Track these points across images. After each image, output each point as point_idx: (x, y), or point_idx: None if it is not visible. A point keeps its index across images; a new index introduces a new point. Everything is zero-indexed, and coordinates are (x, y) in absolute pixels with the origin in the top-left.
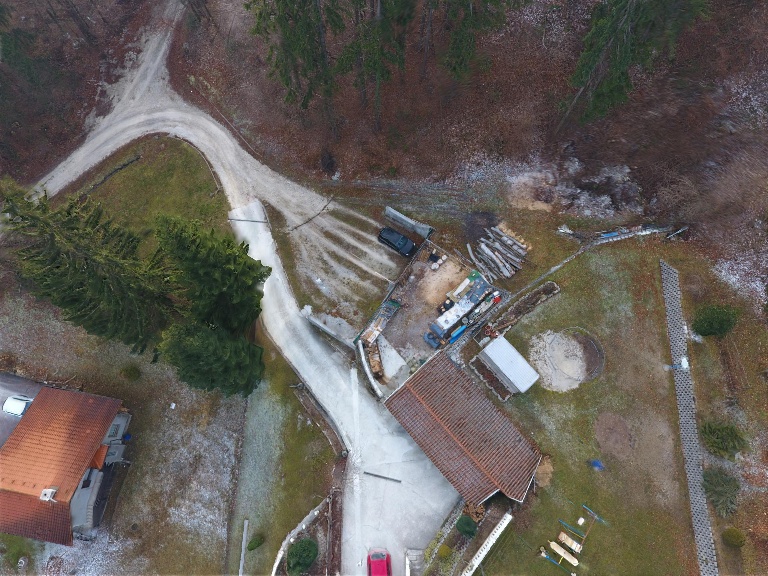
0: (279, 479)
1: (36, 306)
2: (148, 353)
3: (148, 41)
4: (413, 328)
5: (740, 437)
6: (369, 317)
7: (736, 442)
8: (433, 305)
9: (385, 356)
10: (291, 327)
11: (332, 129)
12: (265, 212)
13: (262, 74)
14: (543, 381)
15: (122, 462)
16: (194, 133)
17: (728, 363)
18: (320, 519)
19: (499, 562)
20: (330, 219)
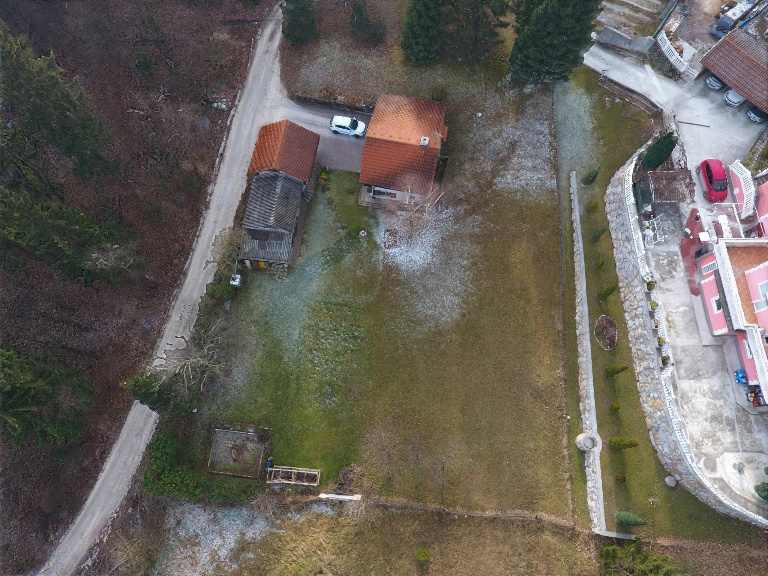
0: (597, 141)
1: (348, 49)
2: (453, 77)
3: None
4: (698, 29)
5: None
6: None
7: None
8: (711, 14)
9: None
10: None
11: None
12: None
13: None
14: None
15: (439, 159)
16: None
17: None
18: None
19: None
20: None
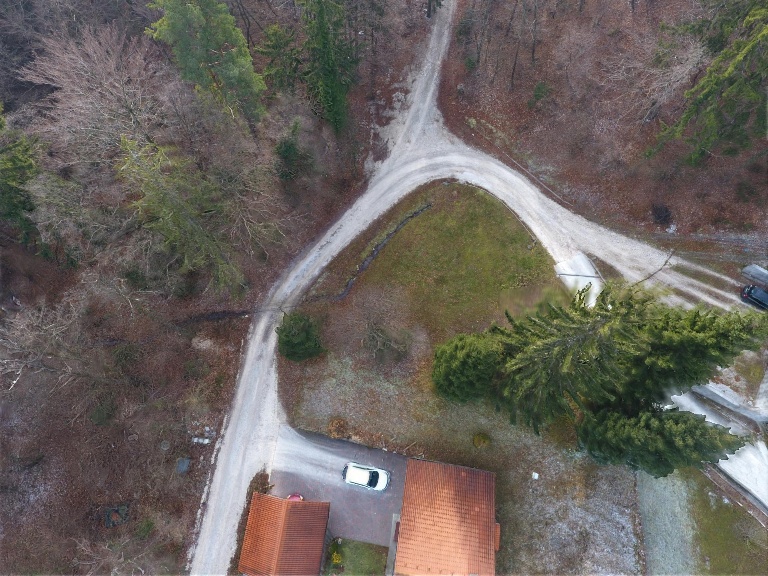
0: (702, 562)
1: (363, 367)
2: (500, 419)
3: (415, 81)
4: None
5: None
6: (753, 383)
7: None
8: None
9: None
10: None
11: (664, 179)
12: (594, 266)
13: (560, 118)
14: None
15: None
16: (486, 179)
17: None
18: None
19: None
20: (676, 275)
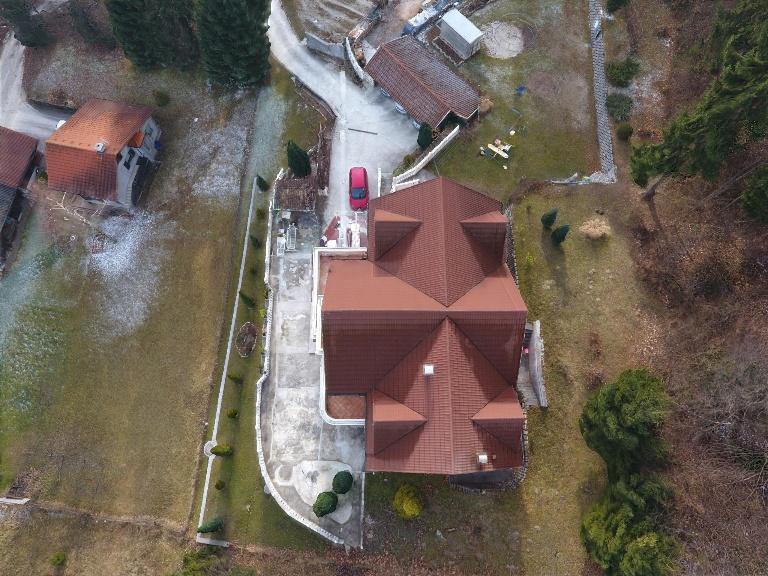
0: (282, 148)
1: (83, 54)
2: (176, 82)
3: None
4: (390, 36)
5: (633, 63)
6: None
7: (630, 68)
8: None
9: (367, 53)
10: (293, 52)
11: None
12: None
13: None
14: (489, 52)
15: (154, 164)
16: None
17: (632, 31)
18: (313, 155)
19: (449, 160)
20: None
